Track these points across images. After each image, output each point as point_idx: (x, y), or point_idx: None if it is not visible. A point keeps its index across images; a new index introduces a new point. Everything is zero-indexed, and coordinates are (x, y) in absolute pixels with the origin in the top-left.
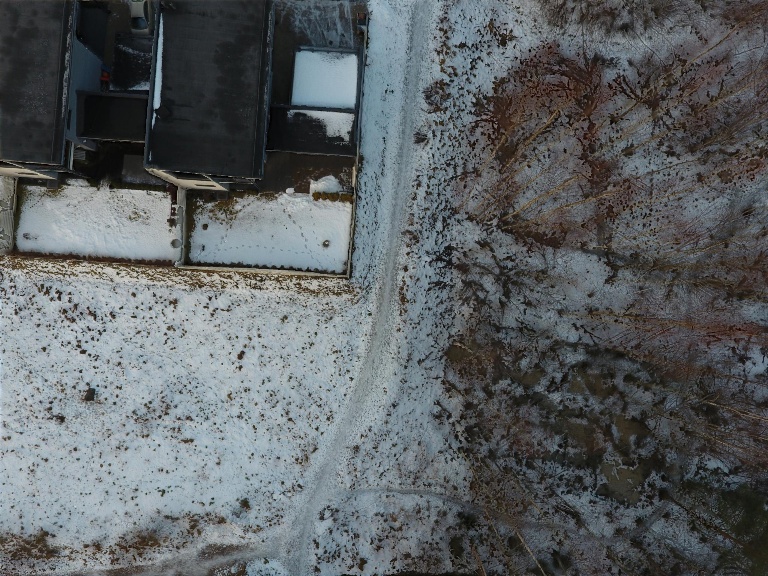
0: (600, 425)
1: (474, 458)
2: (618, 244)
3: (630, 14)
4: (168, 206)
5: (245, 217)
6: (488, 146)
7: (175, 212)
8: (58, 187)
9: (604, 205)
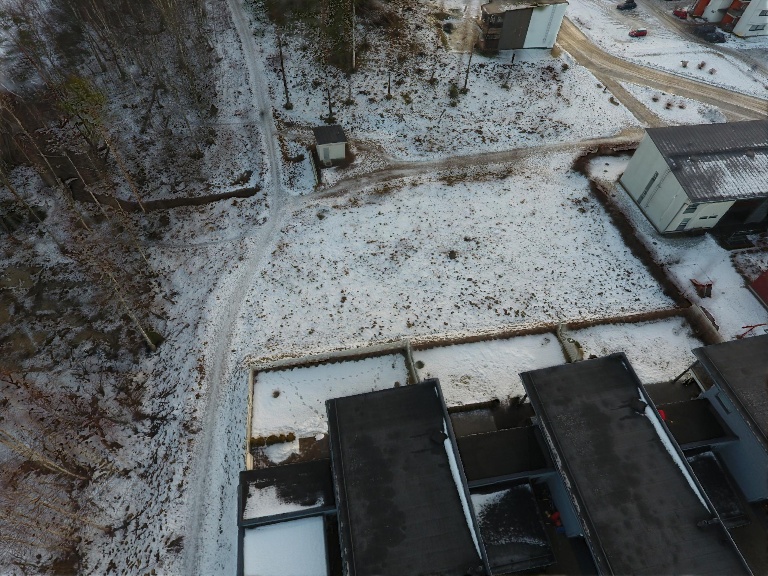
0: (25, 312)
1: (145, 273)
2: None
3: None
4: None
5: None
6: (90, 572)
7: None
8: None
9: None
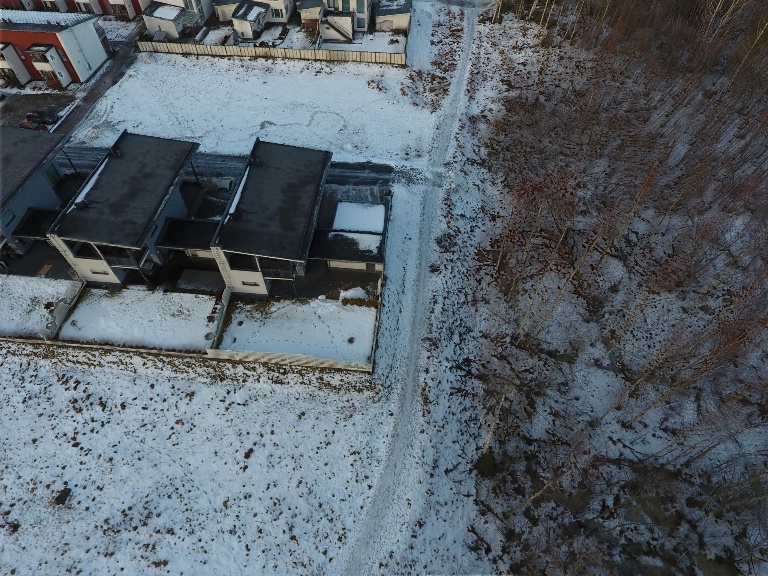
0: (679, 567)
1: None
2: (630, 361)
3: (585, 205)
4: (211, 306)
5: (279, 317)
6: (492, 282)
7: (216, 311)
8: (118, 290)
9: (606, 329)
